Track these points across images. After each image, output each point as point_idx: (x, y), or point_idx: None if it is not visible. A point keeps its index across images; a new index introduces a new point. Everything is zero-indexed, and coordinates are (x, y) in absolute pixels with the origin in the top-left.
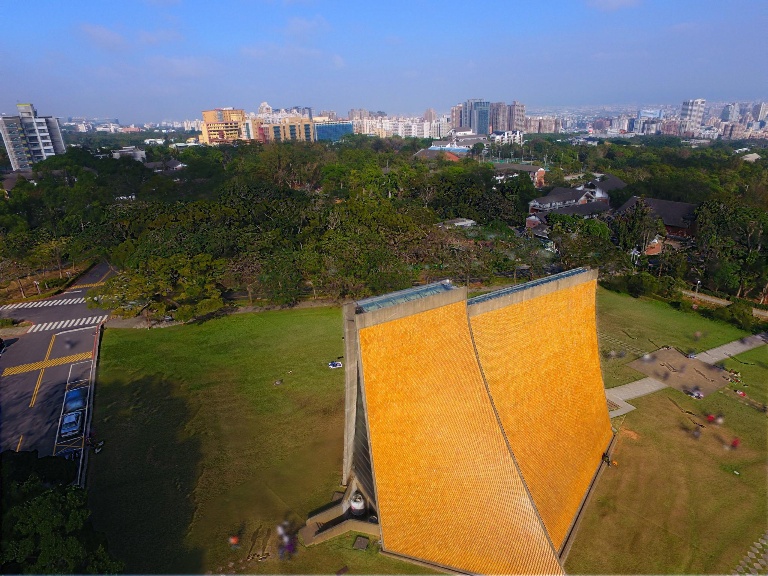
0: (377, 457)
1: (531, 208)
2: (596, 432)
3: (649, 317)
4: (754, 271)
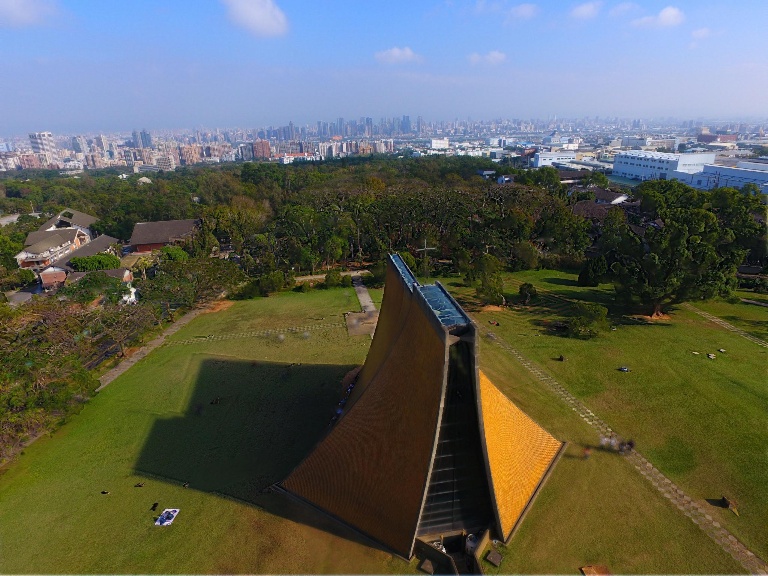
0: (490, 460)
1: (21, 262)
2: None
3: (301, 303)
4: (316, 249)
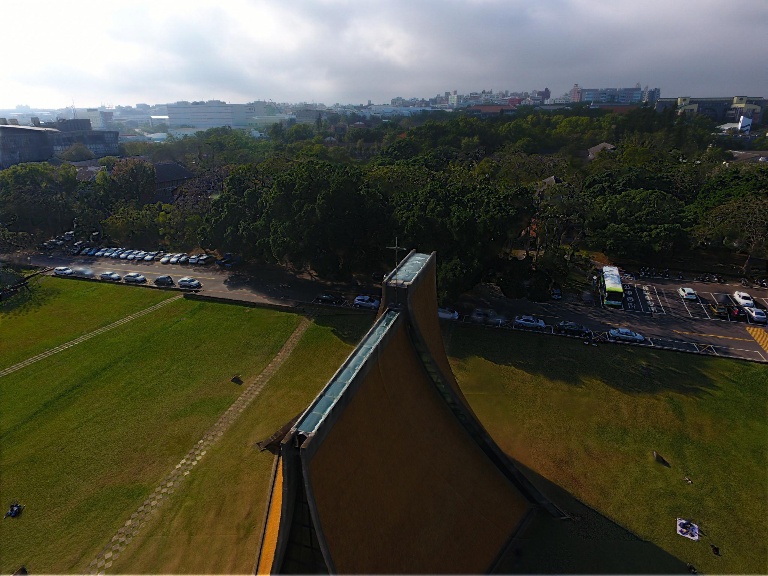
0: None
1: None
2: (265, 575)
3: None
4: None
